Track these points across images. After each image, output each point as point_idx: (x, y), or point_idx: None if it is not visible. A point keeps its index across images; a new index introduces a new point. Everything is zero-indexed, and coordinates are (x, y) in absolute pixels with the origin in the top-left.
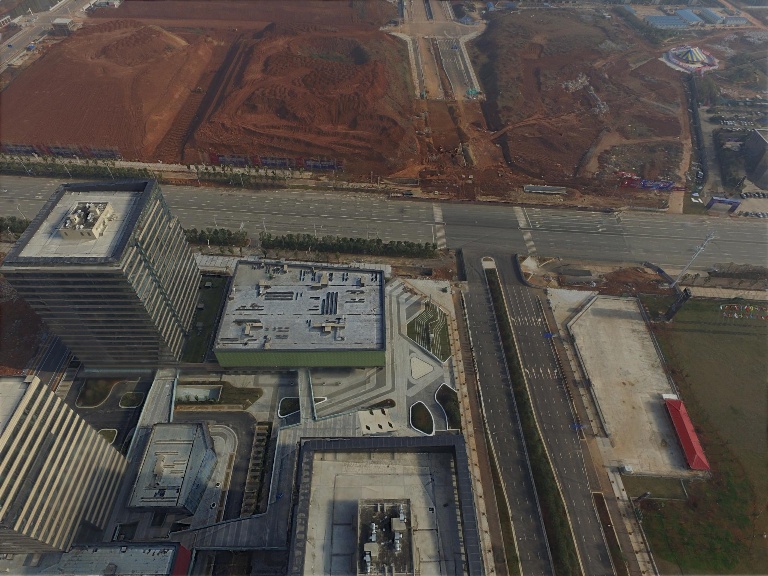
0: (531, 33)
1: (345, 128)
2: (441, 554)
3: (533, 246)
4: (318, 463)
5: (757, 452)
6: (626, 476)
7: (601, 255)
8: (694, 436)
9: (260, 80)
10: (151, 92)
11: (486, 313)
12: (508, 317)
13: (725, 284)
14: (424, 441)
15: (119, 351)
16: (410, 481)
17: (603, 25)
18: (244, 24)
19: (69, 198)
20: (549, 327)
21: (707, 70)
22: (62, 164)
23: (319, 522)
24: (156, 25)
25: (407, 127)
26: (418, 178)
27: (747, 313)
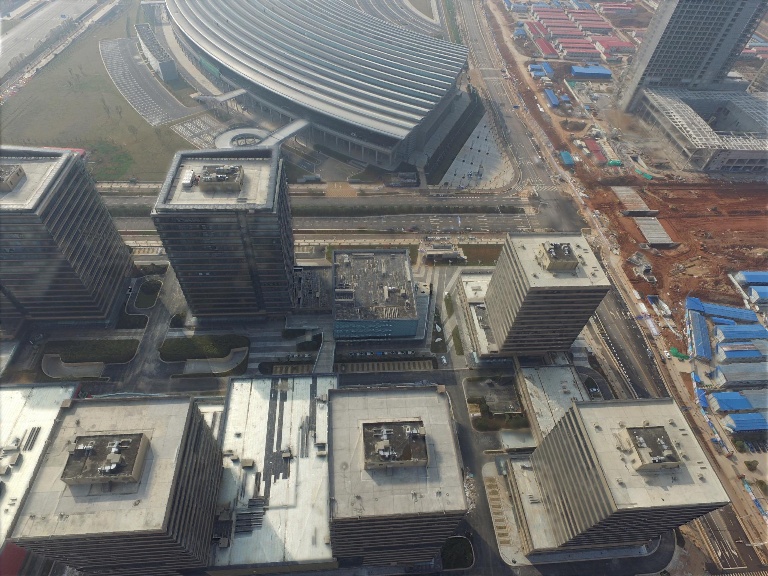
0: None
1: None
2: None
3: None
4: None
5: (88, 133)
6: None
7: None
8: None
9: None
10: None
11: None
12: None
13: None
14: None
15: None
16: None
17: None
18: None
19: None
20: None
21: None
22: None
23: None
24: None
25: None
26: None
27: (2, 99)
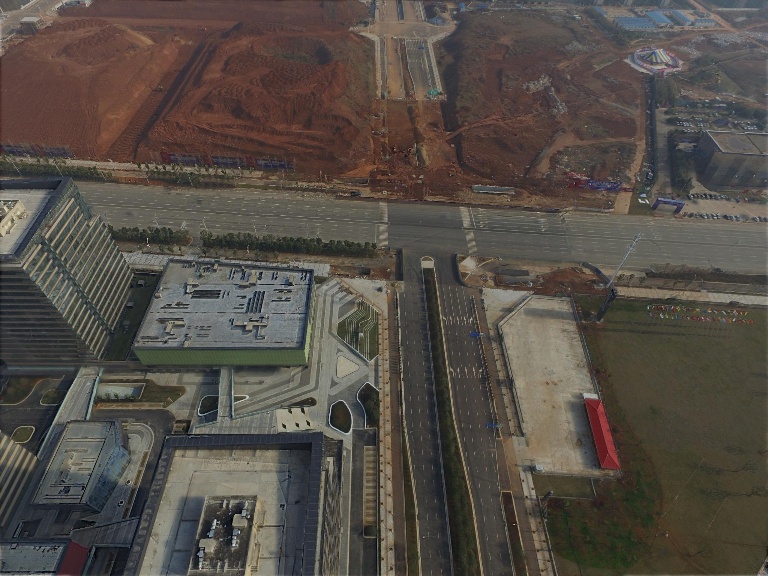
0: (498, 34)
1: (299, 128)
2: (282, 550)
3: (474, 246)
4: (178, 460)
5: (670, 452)
6: (537, 475)
7: (541, 255)
8: (609, 435)
9: (219, 79)
10: (109, 91)
11: (418, 312)
12: (440, 316)
13: (661, 285)
14: (283, 438)
15: (38, 349)
16: (267, 478)
17: (572, 26)
18: (214, 23)
19: None
20: (480, 327)
21: (670, 72)
22: (12, 162)
23: (167, 518)
24: (125, 24)
25: (362, 127)
26: (368, 178)
27: (672, 313)
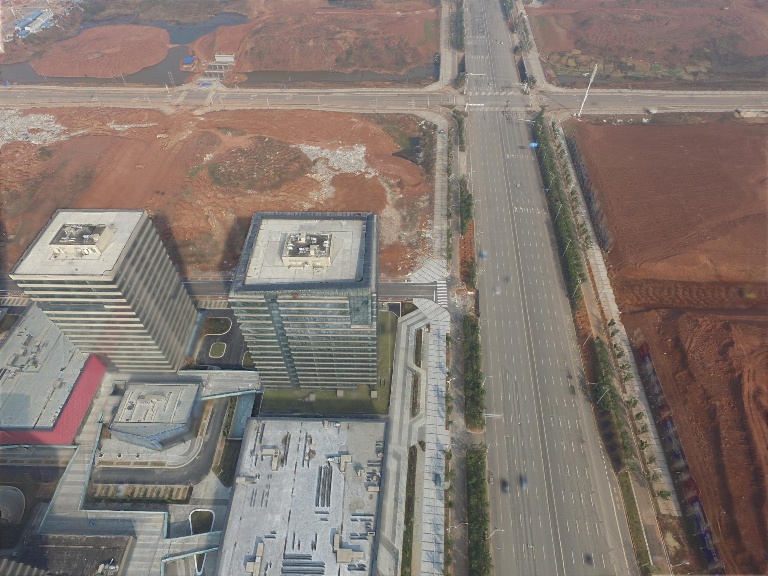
0: None
1: None
2: None
3: None
4: None
5: None
6: None
7: None
8: None
9: None
10: (756, 238)
11: None
12: None
13: None
14: None
15: None
16: None
17: None
18: None
19: (356, 226)
20: None
21: None
22: (566, 208)
23: None
24: None
25: None
26: None
27: None
